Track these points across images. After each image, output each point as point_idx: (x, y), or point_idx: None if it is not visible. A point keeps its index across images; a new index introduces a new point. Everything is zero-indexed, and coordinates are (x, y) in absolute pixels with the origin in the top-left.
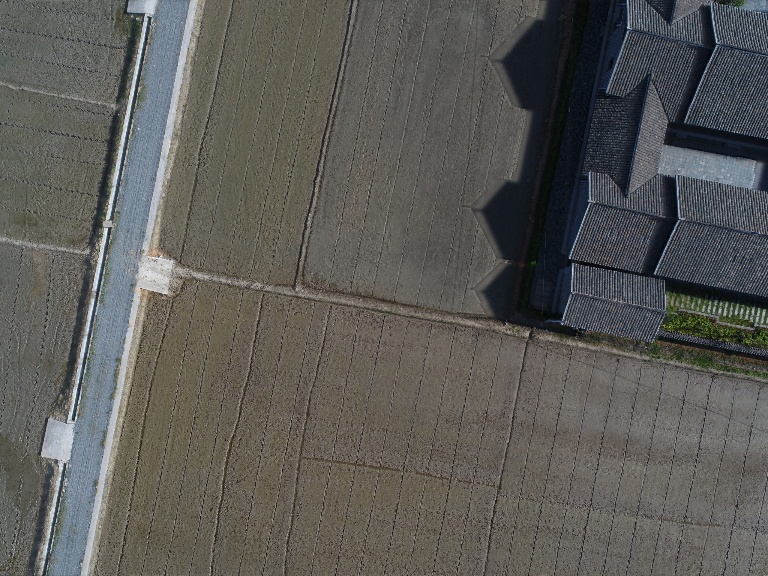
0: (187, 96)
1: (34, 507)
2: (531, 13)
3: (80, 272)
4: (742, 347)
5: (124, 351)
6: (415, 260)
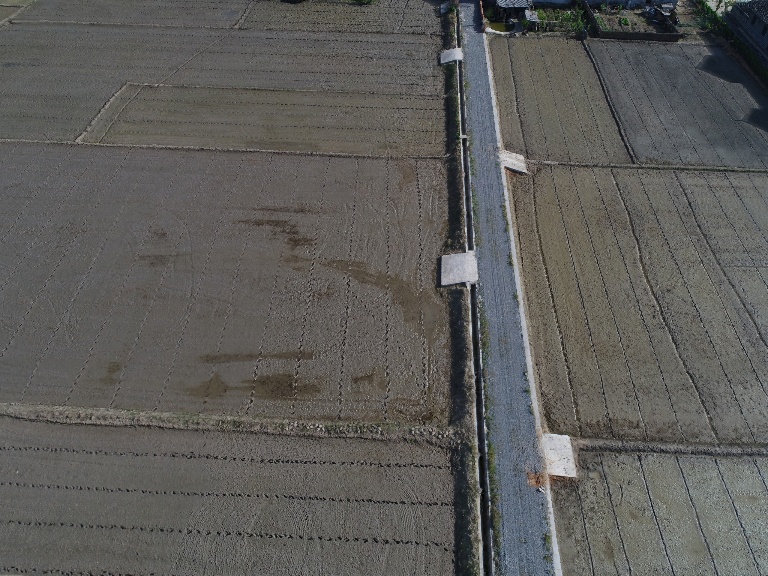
0: (496, 90)
1: (442, 334)
2: (707, 54)
3: (443, 168)
4: None
5: (506, 201)
6: (723, 146)
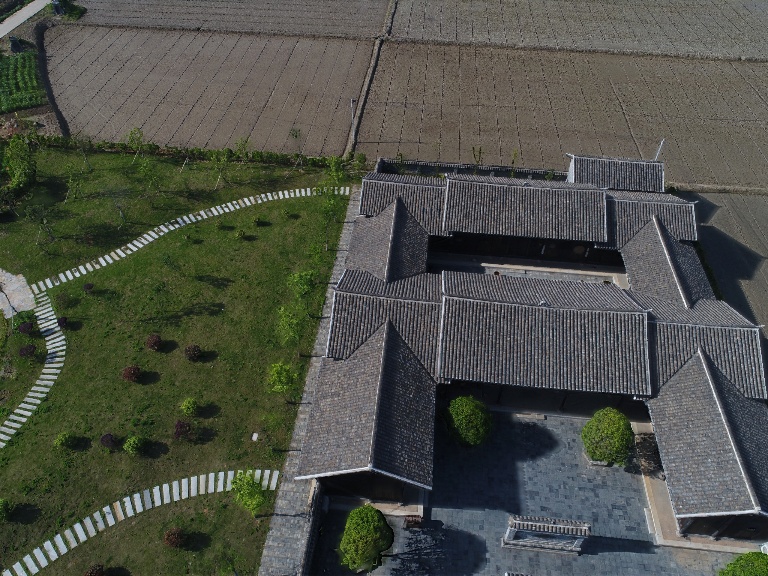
0: None
1: None
2: None
3: None
4: (478, 165)
5: None
6: None
